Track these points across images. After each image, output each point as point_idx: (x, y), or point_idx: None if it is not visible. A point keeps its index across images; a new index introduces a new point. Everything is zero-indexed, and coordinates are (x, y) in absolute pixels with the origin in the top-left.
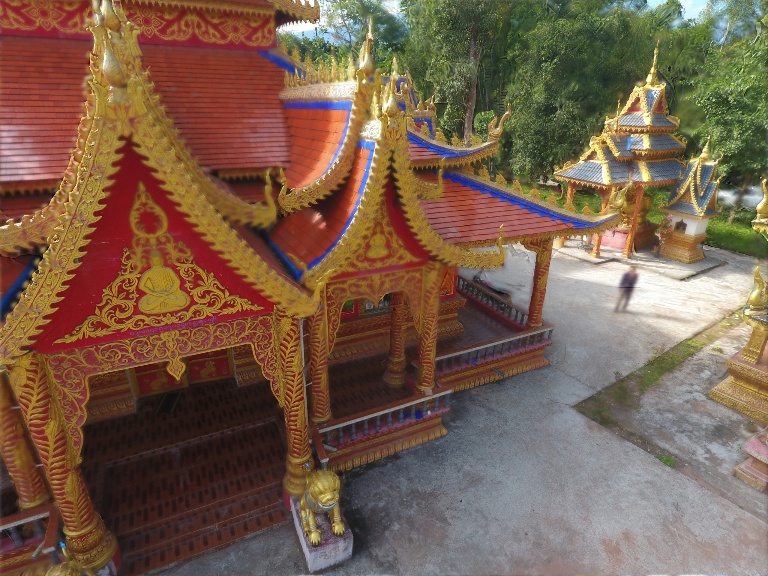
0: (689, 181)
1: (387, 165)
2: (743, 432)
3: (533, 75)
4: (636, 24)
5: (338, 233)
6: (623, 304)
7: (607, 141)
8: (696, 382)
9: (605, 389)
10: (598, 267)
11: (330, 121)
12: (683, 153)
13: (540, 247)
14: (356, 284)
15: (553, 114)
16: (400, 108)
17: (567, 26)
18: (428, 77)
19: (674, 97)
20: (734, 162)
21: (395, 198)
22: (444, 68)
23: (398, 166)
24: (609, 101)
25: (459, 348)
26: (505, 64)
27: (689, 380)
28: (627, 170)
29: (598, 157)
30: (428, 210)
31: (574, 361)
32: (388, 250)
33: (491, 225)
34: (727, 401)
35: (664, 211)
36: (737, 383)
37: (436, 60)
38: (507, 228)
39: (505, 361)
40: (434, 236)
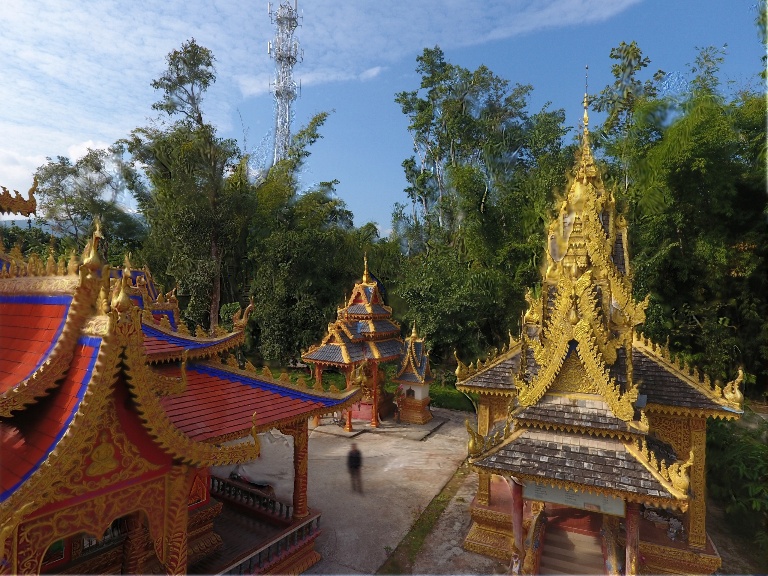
0: (408, 355)
1: (117, 362)
2: (496, 575)
3: (272, 273)
4: (348, 239)
5: (43, 451)
6: (380, 473)
7: (342, 327)
8: (452, 537)
9: (379, 570)
10: (353, 440)
11: (41, 317)
12: (399, 334)
13: (296, 430)
14: (68, 516)
15: (294, 305)
16: (136, 301)
17: (296, 236)
18: (169, 271)
19: (385, 292)
20: (435, 339)
21: (127, 398)
22: (186, 264)
23: (131, 363)
24: (338, 294)
25: (217, 568)
26: (246, 263)
27: (446, 536)
28: (361, 350)
29: (337, 340)
30: (171, 406)
31: (346, 547)
32: (118, 462)
33: (244, 414)
34: (478, 548)
35: (396, 382)
36: (481, 528)
37: (177, 257)
38: (261, 415)
39: (274, 569)
40: (178, 436)
